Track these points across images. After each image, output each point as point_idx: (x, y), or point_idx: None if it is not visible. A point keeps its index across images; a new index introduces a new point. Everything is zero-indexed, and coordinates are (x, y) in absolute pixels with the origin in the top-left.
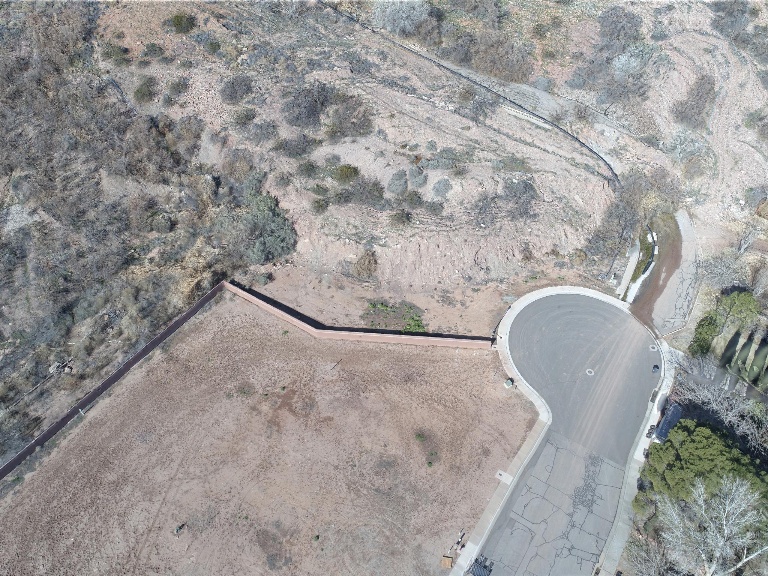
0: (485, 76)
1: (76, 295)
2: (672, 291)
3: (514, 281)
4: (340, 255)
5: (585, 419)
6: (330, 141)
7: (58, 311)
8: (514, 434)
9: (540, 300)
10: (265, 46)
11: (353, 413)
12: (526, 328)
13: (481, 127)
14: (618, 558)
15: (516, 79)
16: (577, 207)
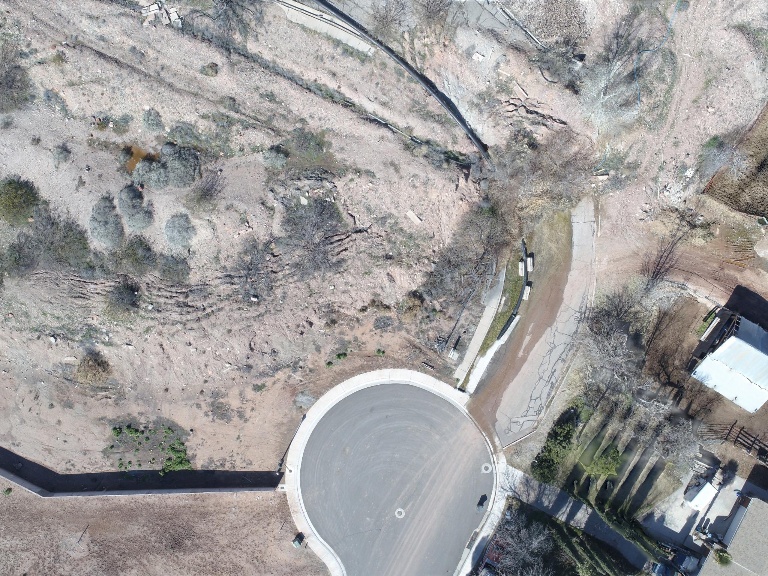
0: None
1: None
2: (533, 369)
3: (313, 364)
4: (51, 358)
5: None
6: None
7: None
8: None
9: (347, 400)
10: None
11: None
12: (324, 451)
13: (238, 66)
14: None
15: None
16: (411, 228)
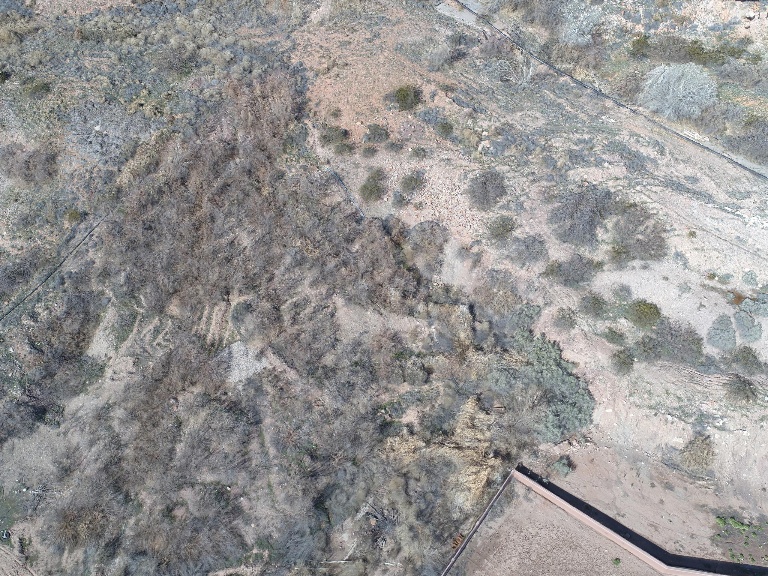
0: None
1: (326, 480)
2: None
3: None
4: (660, 437)
5: None
6: (613, 265)
7: (308, 506)
8: None
9: None
10: (509, 130)
11: None
12: None
13: None
14: None
15: None
16: None
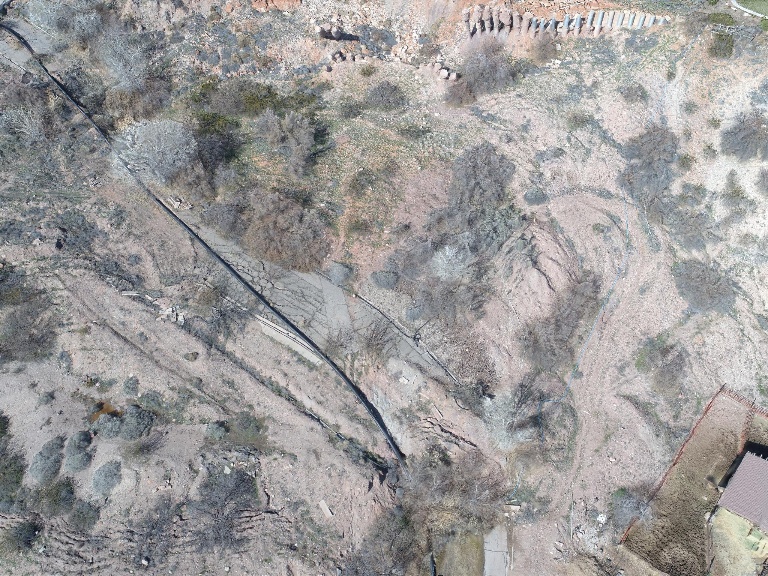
0: (255, 259)
1: None
2: None
3: None
4: None
5: None
6: None
7: None
8: None
9: None
10: None
11: None
12: None
13: (213, 357)
14: None
15: (301, 265)
16: (321, 521)
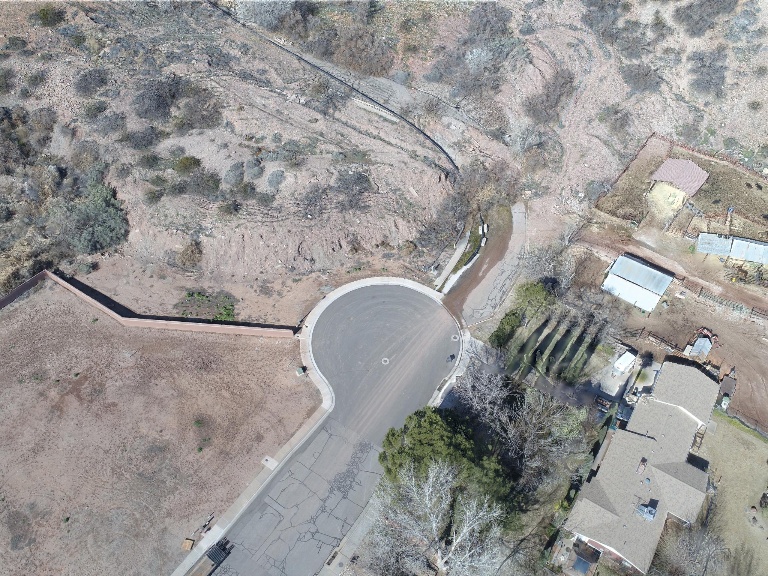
0: (344, 69)
1: None
2: (489, 282)
3: (337, 272)
4: (167, 245)
5: (367, 407)
6: (178, 133)
7: None
8: (292, 421)
9: (356, 290)
10: (129, 39)
11: (139, 399)
12: (334, 318)
13: (328, 120)
14: (358, 542)
15: (375, 73)
16: (411, 199)
